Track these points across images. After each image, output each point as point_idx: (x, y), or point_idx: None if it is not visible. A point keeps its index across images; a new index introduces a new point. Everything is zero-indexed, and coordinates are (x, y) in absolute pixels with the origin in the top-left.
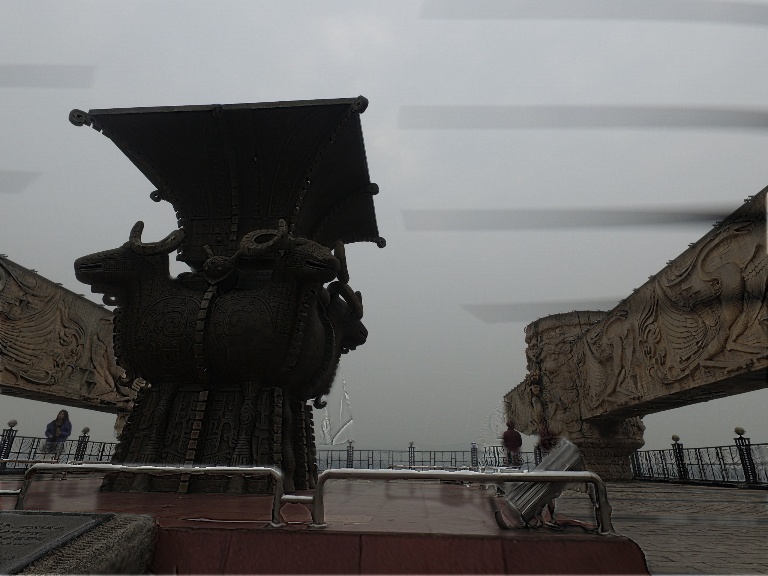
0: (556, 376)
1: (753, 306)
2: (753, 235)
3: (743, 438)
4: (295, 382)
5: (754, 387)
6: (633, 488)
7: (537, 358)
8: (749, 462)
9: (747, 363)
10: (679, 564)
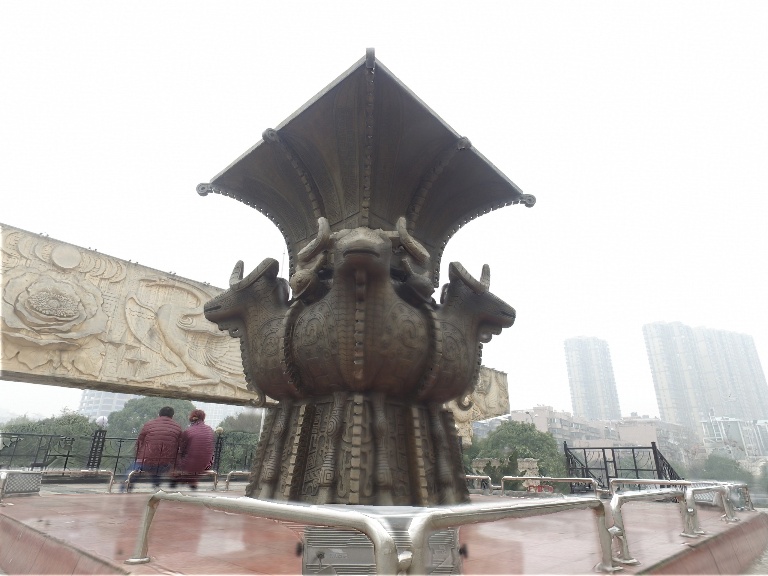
0: None
1: None
2: None
3: None
4: None
5: None
6: None
7: None
8: None
9: None
10: None
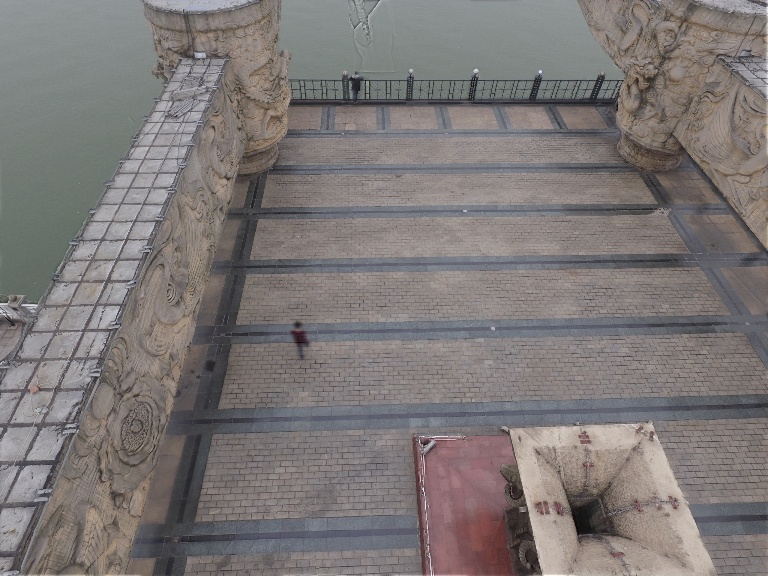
0: (675, 85)
1: None
2: None
3: None
4: None
5: None
6: (685, 278)
7: (666, 53)
8: None
9: None
10: None
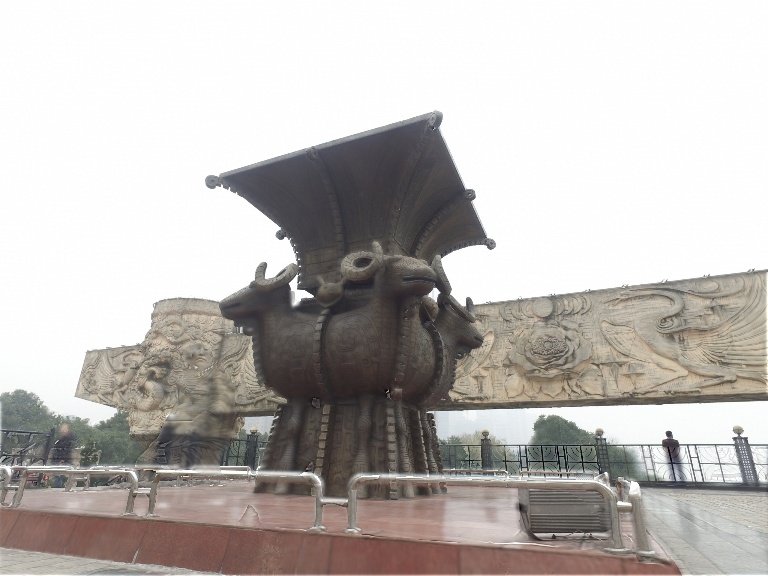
0: None
1: None
2: None
3: None
4: (302, 391)
5: None
6: None
7: None
8: None
9: None
10: None
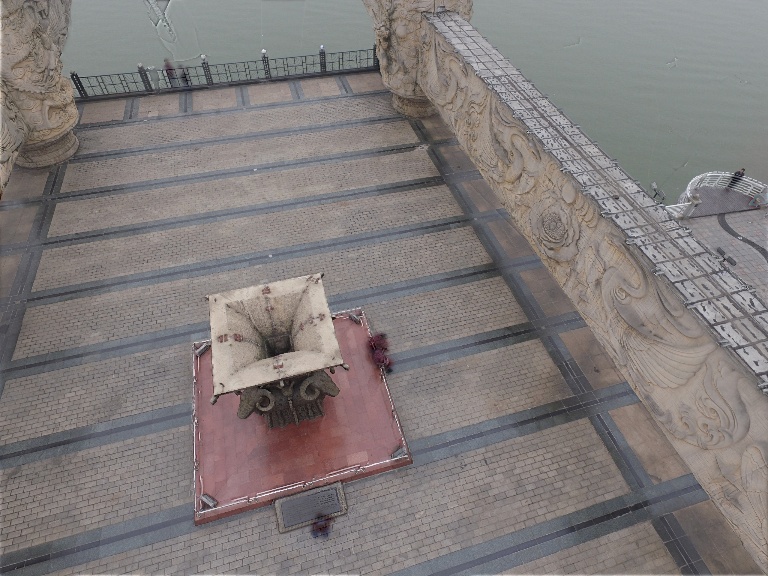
0: (403, 41)
1: (517, 189)
2: (536, 165)
3: None
4: None
5: None
6: (433, 194)
7: (389, 16)
8: None
9: (502, 203)
10: (419, 431)
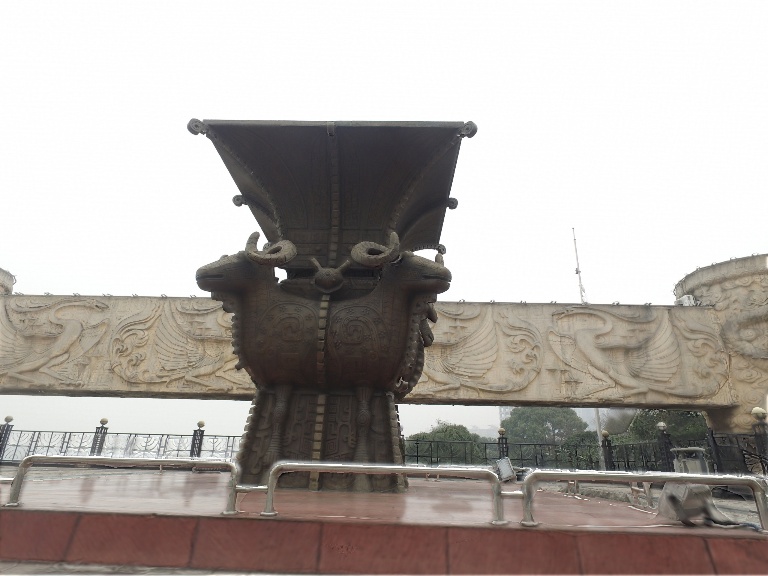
0: None
1: None
2: None
3: (104, 427)
4: None
5: (188, 398)
6: (59, 471)
7: None
8: (99, 447)
9: (229, 388)
10: None
